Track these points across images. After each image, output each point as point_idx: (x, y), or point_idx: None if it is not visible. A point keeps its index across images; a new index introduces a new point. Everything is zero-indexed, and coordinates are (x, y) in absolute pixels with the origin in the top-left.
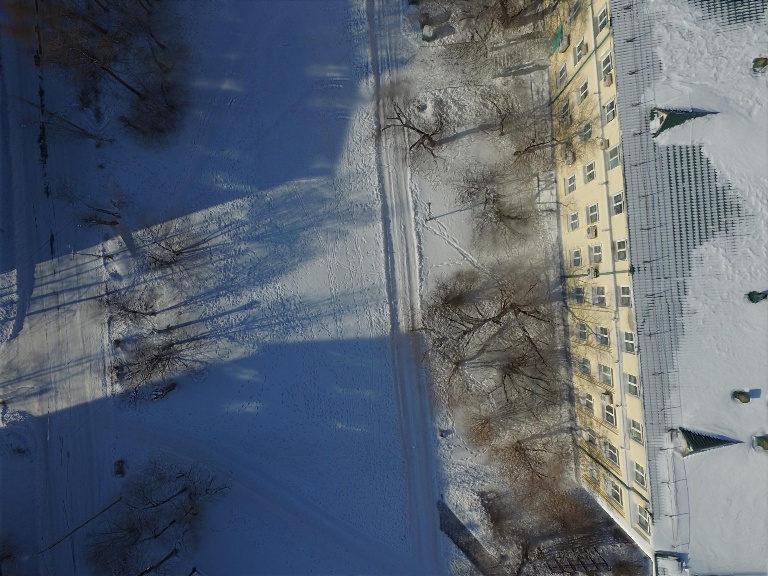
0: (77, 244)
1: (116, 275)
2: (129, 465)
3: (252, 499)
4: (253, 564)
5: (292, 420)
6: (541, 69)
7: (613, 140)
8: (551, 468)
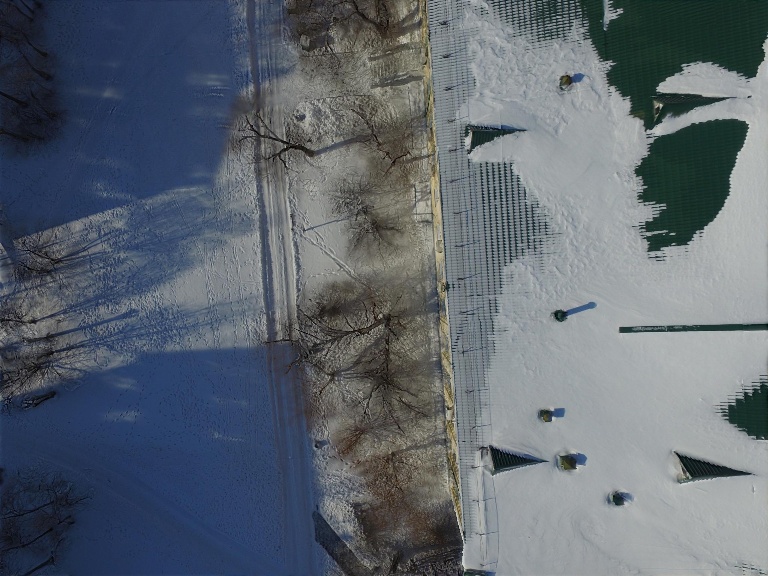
0: None
1: None
2: (7, 473)
3: (129, 508)
4: (128, 573)
5: (169, 429)
6: (417, 80)
7: None
8: (425, 480)
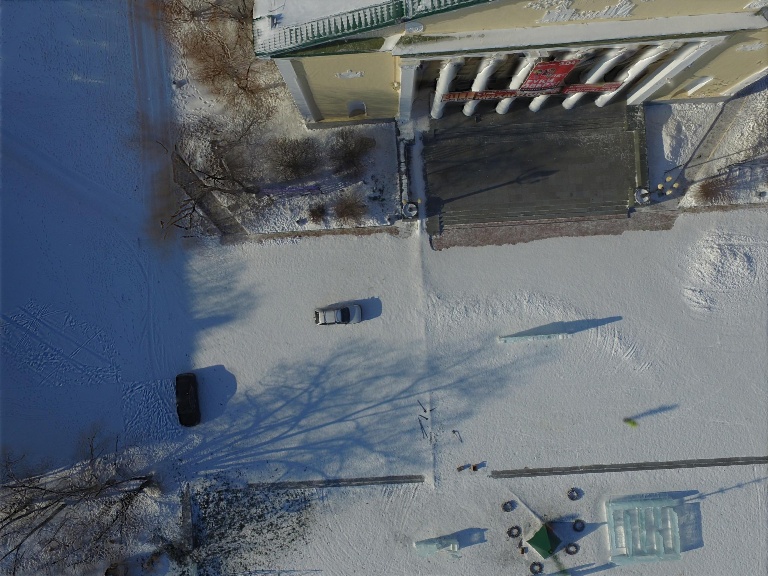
0: None
1: None
2: None
3: None
4: None
5: (29, 73)
6: None
7: None
8: (283, 117)
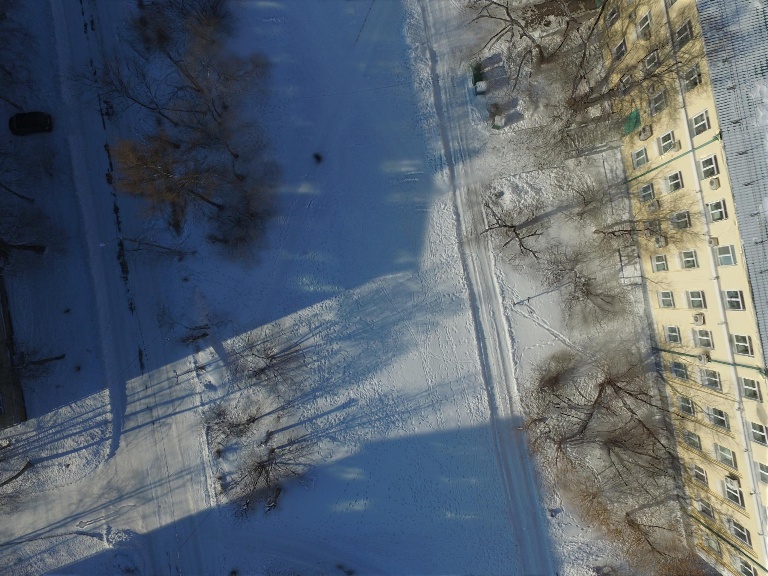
0: (166, 357)
1: (210, 386)
2: (242, 575)
3: None
4: None
5: (401, 514)
6: (613, 149)
7: (724, 240)
8: (662, 536)
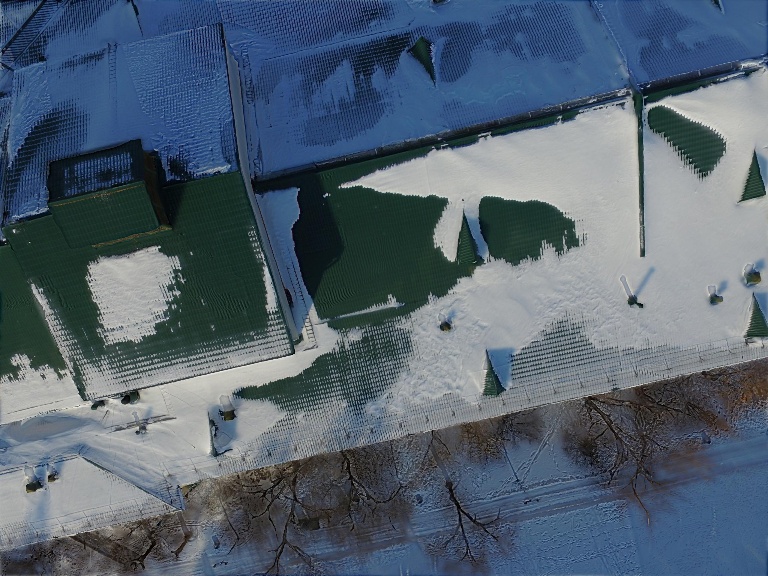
0: None
1: None
2: None
3: None
4: None
5: None
6: None
7: None
8: None
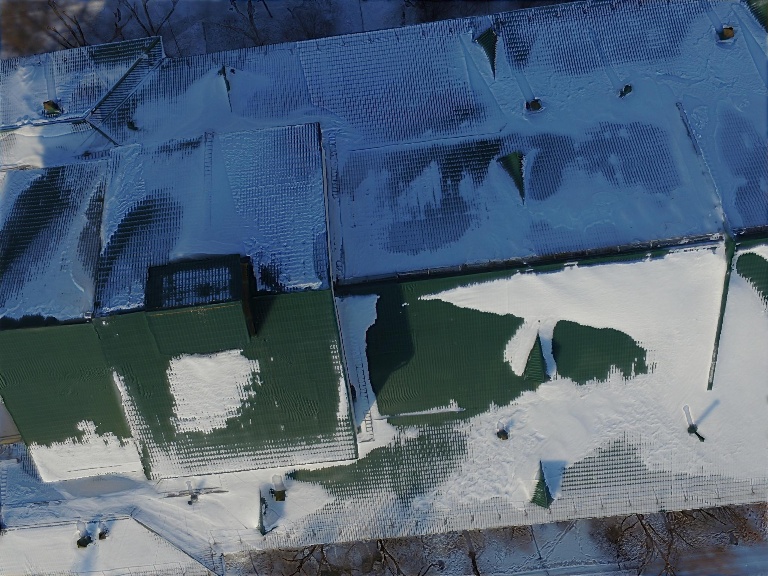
0: None
1: None
2: None
3: None
4: None
5: None
6: None
7: None
8: None
